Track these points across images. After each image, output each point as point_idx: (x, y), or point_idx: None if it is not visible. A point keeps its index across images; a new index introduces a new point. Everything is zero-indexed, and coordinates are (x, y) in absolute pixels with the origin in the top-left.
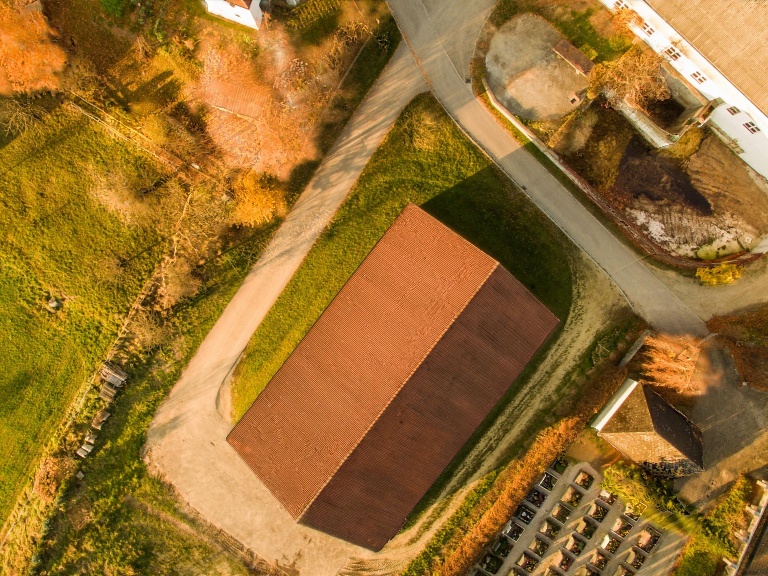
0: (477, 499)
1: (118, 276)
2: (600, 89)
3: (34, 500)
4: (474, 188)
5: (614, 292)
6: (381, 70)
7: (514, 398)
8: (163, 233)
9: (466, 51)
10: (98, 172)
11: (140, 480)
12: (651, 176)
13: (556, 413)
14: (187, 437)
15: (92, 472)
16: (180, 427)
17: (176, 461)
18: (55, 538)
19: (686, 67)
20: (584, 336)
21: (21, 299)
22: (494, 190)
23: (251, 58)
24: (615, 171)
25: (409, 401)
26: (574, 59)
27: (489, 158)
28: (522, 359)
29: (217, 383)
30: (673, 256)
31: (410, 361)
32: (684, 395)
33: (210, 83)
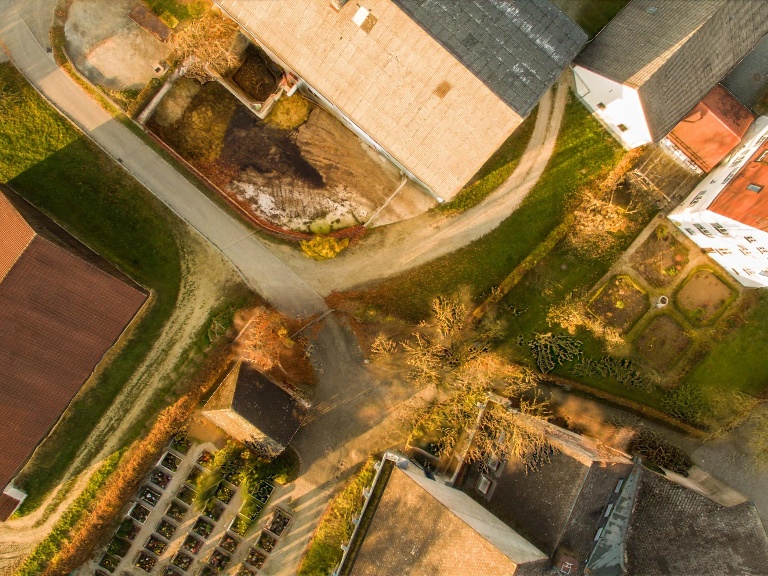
0: (102, 480)
1: None
2: (175, 57)
3: None
4: (67, 161)
5: (227, 267)
6: None
7: (131, 377)
8: None
9: (44, 19)
10: None
11: None
12: (259, 148)
13: (176, 392)
14: None
15: None
16: None
17: None
18: None
19: None
20: (198, 313)
21: None
22: (88, 163)
23: None
24: (220, 143)
25: None
26: (151, 26)
27: (79, 130)
28: (105, 335)
29: None
30: (268, 229)
31: None
32: (305, 373)
33: None
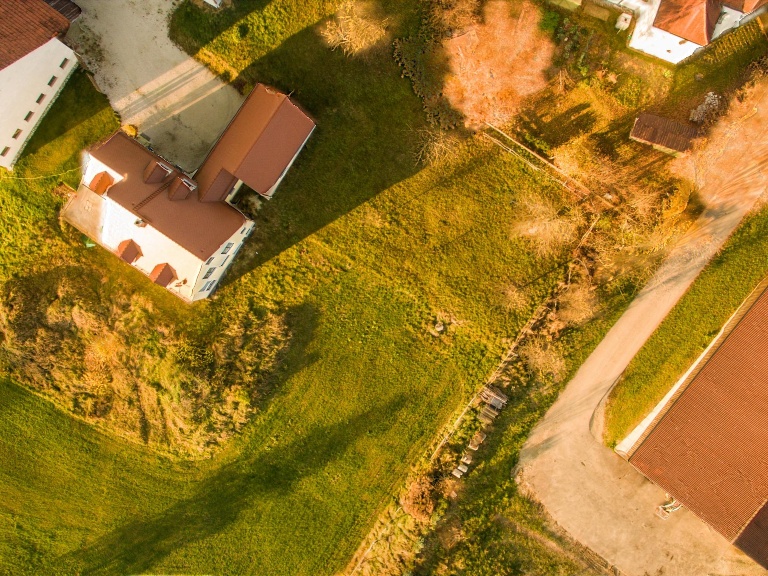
0: None
1: (511, 301)
2: None
3: (399, 519)
4: None
5: None
6: None
7: None
8: (560, 260)
9: None
10: (504, 201)
11: (510, 499)
12: None
13: None
14: (559, 457)
15: (464, 492)
16: (553, 448)
17: (546, 481)
18: (423, 556)
19: None
20: None
21: (407, 323)
22: None
23: (669, 91)
24: None
25: None
26: None
27: None
28: None
29: (593, 405)
30: None
31: None
32: None
33: (628, 115)
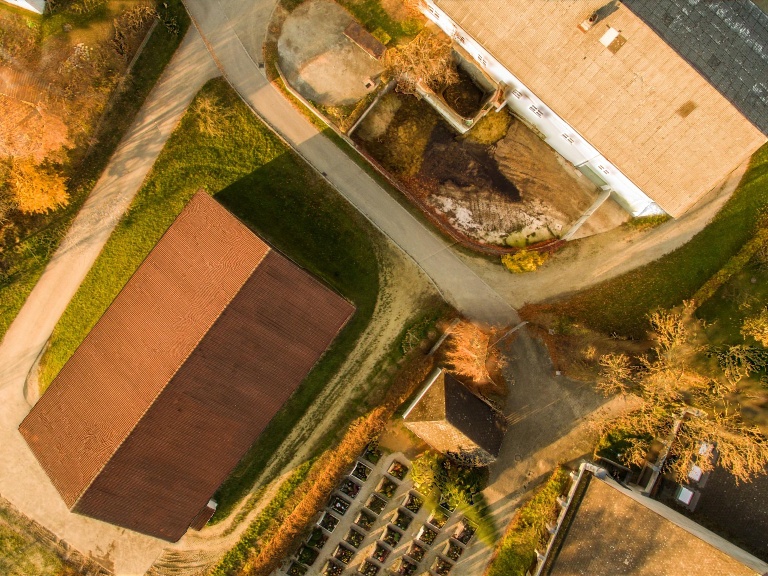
0: (291, 490)
1: None
2: (391, 73)
3: None
4: (273, 174)
5: (423, 280)
6: (172, 55)
7: (325, 387)
8: None
9: (258, 35)
10: None
11: None
12: (457, 162)
13: (368, 403)
14: None
15: None
16: None
17: None
18: None
19: (472, 50)
20: (393, 324)
21: None
22: (293, 176)
23: (35, 43)
24: (420, 157)
25: (186, 389)
26: (365, 43)
27: (287, 144)
28: (316, 347)
29: (24, 372)
30: (473, 243)
31: (181, 348)
32: (497, 384)
33: None
